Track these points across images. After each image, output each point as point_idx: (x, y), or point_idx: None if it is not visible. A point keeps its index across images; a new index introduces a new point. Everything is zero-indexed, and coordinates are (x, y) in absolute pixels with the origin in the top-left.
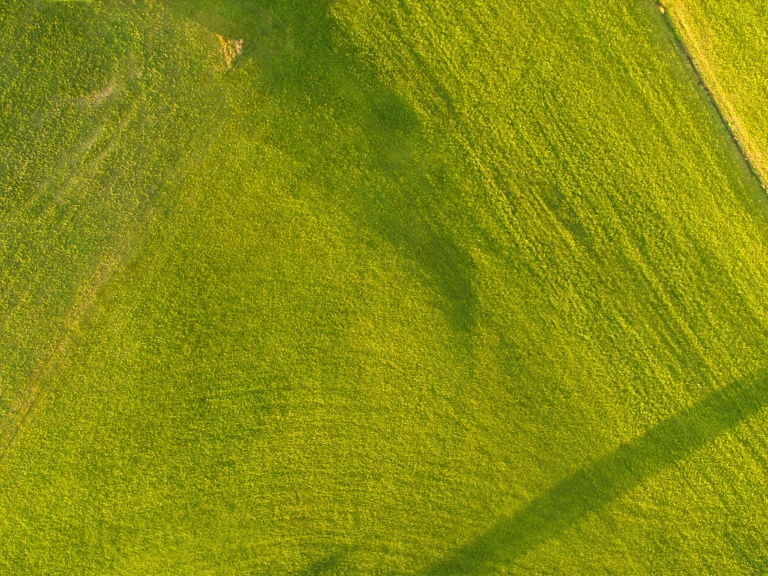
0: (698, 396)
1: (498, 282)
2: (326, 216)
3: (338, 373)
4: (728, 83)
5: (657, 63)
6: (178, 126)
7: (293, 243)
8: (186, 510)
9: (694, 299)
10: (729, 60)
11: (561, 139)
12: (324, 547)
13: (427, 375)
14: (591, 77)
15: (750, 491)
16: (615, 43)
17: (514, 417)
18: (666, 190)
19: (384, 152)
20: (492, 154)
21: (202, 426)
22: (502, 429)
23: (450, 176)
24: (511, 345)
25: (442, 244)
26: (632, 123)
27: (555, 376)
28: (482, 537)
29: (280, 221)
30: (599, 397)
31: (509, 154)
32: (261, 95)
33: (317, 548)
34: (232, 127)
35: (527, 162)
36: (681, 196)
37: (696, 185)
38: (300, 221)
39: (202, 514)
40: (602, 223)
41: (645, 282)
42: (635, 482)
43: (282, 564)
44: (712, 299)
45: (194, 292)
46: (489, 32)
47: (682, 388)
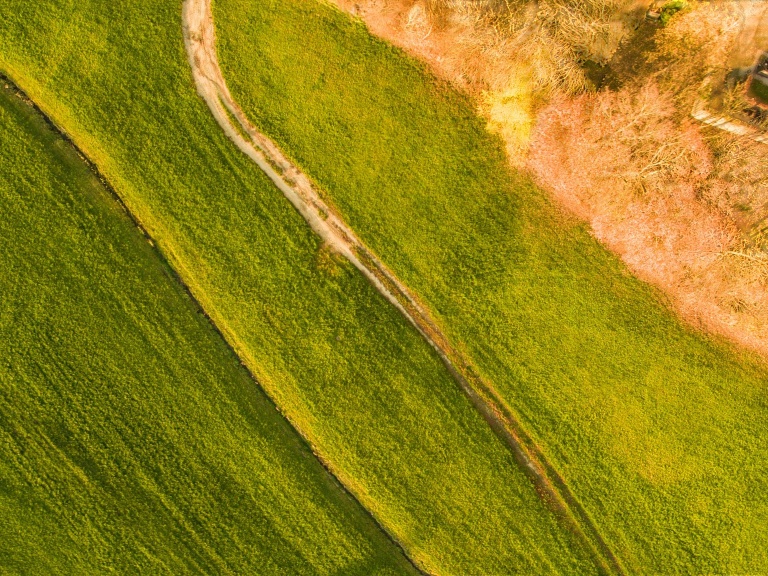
0: None
1: (14, 521)
2: None
3: None
4: (227, 310)
5: (151, 296)
6: None
7: None
8: None
9: (218, 525)
10: (225, 288)
11: (62, 378)
12: None
13: None
14: (84, 315)
15: None
16: (105, 280)
17: None
18: (175, 420)
19: None
20: None
21: None
22: None
23: None
24: None
25: None
26: (132, 357)
27: None
28: None
29: None
30: None
31: (11, 396)
32: None
33: None
34: None
35: (30, 403)
36: (192, 425)
37: (206, 413)
38: None
39: None
40: (114, 456)
41: (165, 511)
42: None
43: None
44: (237, 523)
45: None
46: None
47: None
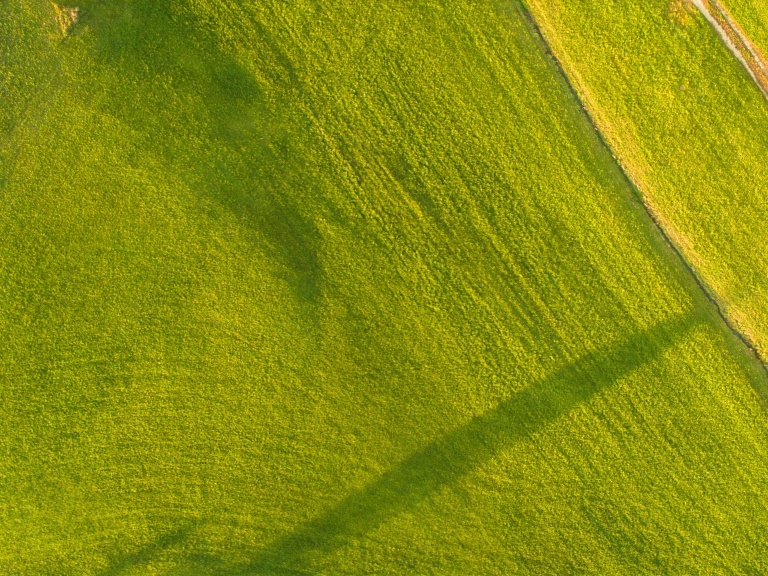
0: (551, 368)
1: (344, 253)
2: (166, 186)
3: (182, 344)
4: (576, 52)
5: (503, 32)
6: (13, 94)
7: (133, 213)
8: (30, 482)
9: (545, 270)
10: (576, 29)
11: (407, 109)
12: (172, 520)
13: (273, 346)
14: (436, 46)
15: (606, 464)
16: (460, 12)
17: (363, 389)
18: (515, 160)
19: (225, 121)
20: (336, 124)
21: (44, 397)
22: (351, 401)
23: (294, 146)
24: (359, 316)
25: (286, 214)
26: (479, 92)
27: (405, 348)
28: (333, 510)
29: (119, 191)
30: (450, 369)
31: (354, 124)
32: (98, 63)
33: (165, 521)
34: (68, 96)
35: (372, 132)
36: (530, 166)
37: (545, 155)
38: (139, 191)
39: (47, 486)
40: (450, 193)
41: (495, 253)
42: (489, 455)
43: (130, 537)
44: (564, 270)
45: (32, 262)
46: (331, 0)
47: (535, 360)
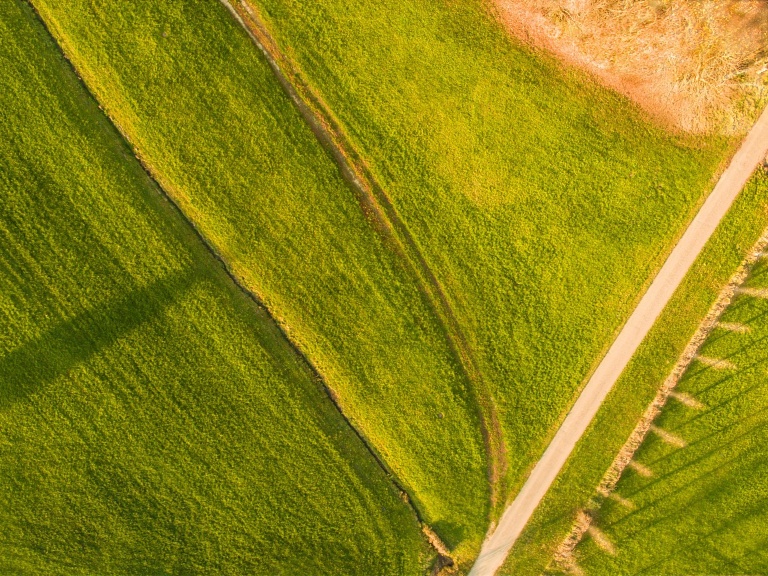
0: (46, 327)
1: None
2: None
3: None
4: None
5: None
6: None
7: None
8: None
9: (34, 226)
10: None
11: None
12: None
13: None
14: None
15: (112, 427)
16: None
17: None
18: None
19: None
20: None
21: None
22: None
23: None
24: None
25: None
26: None
27: None
28: None
29: None
30: None
31: None
32: None
33: None
34: None
35: None
36: (10, 117)
37: (25, 106)
38: None
39: None
40: None
41: None
42: None
43: None
44: (54, 226)
45: None
46: None
47: (28, 319)
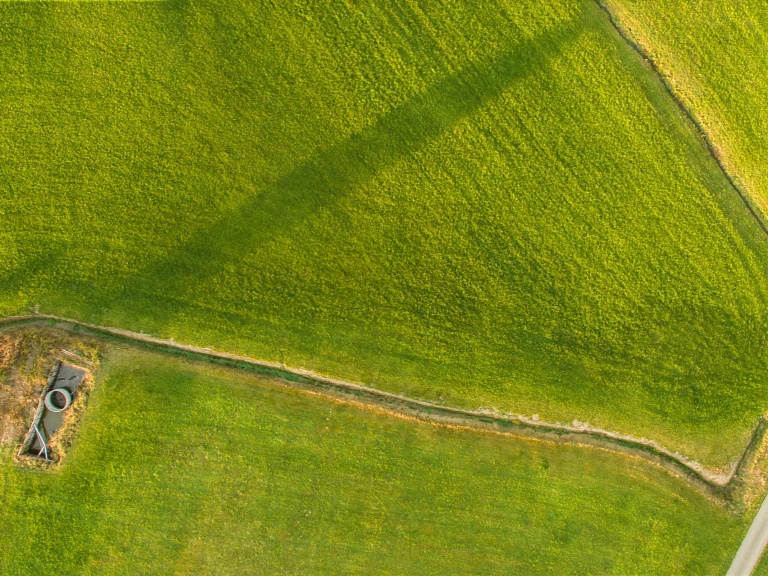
0: (432, 82)
1: None
2: None
3: (45, 56)
4: None
5: None
6: None
7: None
8: None
9: None
10: None
11: None
12: (42, 244)
13: (139, 58)
14: None
15: (495, 186)
16: None
17: (234, 104)
18: None
19: None
20: None
21: None
22: (222, 117)
23: None
24: (227, 26)
25: None
26: None
27: (277, 60)
28: (208, 234)
29: None
30: (326, 83)
31: None
32: None
33: (35, 245)
34: None
35: None
36: None
37: None
38: None
39: None
40: None
41: None
42: (369, 176)
43: None
44: None
45: None
46: None
47: (414, 73)
